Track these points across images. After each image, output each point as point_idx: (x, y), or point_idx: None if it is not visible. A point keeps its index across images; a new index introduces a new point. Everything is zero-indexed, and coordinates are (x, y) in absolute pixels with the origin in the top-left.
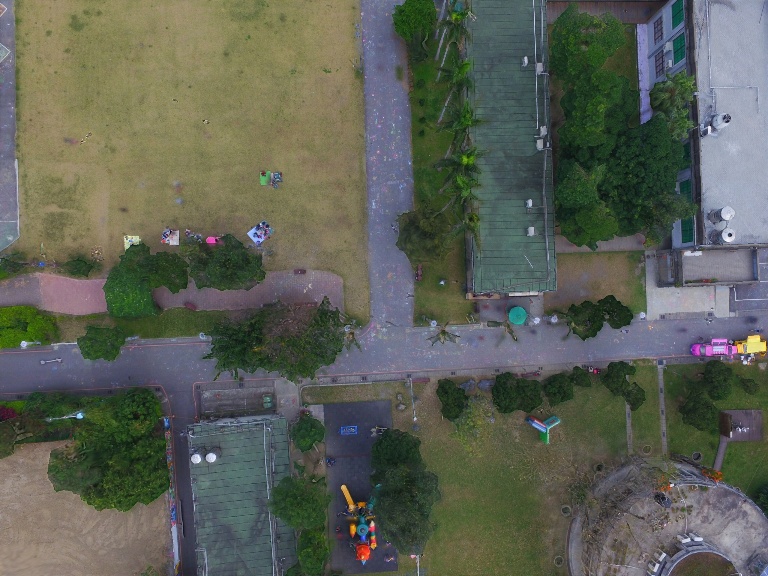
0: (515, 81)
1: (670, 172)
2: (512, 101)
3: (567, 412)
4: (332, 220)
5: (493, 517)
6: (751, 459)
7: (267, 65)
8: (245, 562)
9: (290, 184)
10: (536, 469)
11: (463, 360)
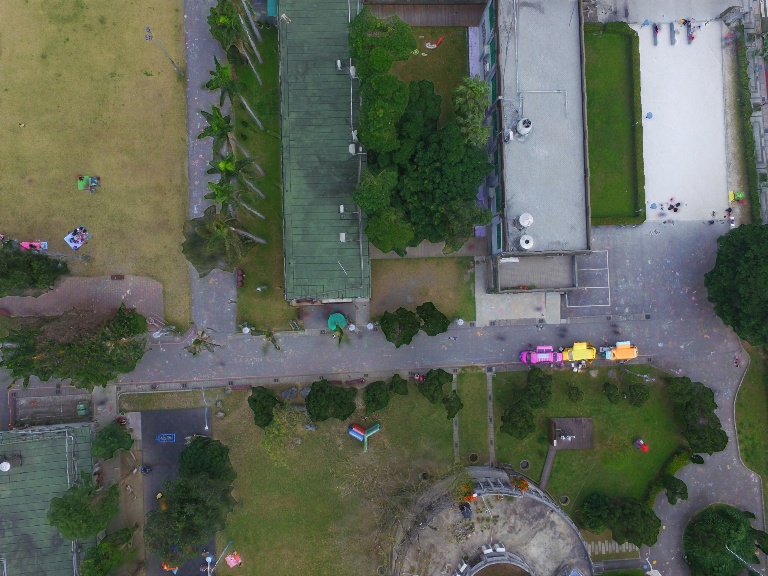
0: (330, 85)
1: (468, 178)
2: (327, 105)
3: (392, 420)
4: (152, 225)
5: (314, 526)
6: (581, 467)
7: (86, 68)
8: (46, 572)
9: (109, 189)
10: (359, 477)
11: (286, 367)
